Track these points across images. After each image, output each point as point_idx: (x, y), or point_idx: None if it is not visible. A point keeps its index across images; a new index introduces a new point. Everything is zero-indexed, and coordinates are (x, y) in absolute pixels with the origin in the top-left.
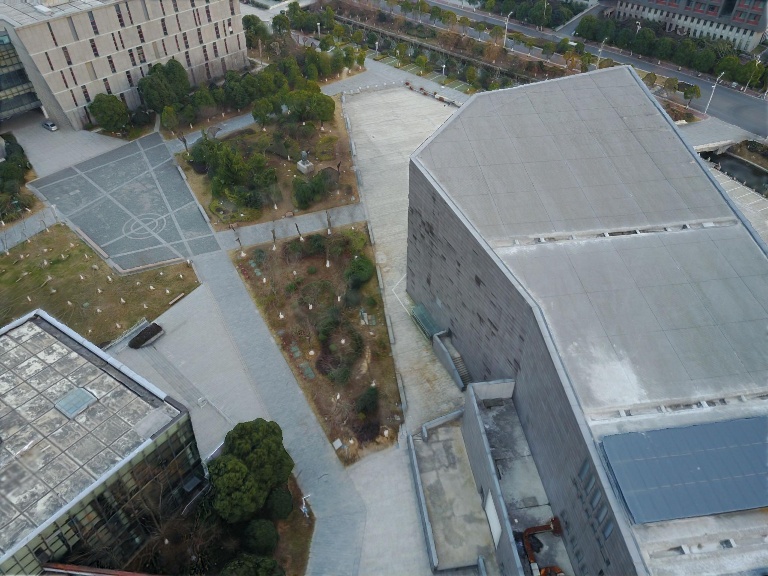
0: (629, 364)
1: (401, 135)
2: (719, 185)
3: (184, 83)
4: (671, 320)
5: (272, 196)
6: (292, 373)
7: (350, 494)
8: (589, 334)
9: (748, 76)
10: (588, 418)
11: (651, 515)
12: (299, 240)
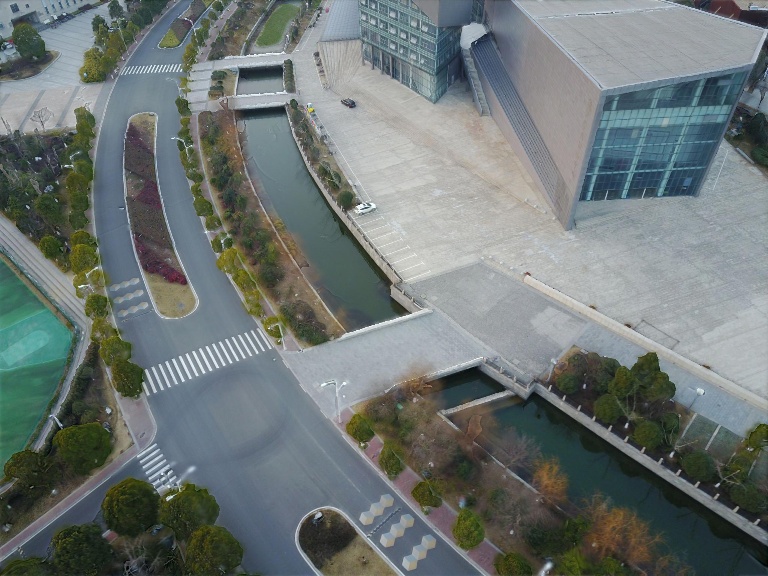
0: None
1: None
2: (539, 27)
3: None
4: None
5: None
6: (760, 111)
7: None
8: None
9: (205, 491)
10: None
11: None
12: None
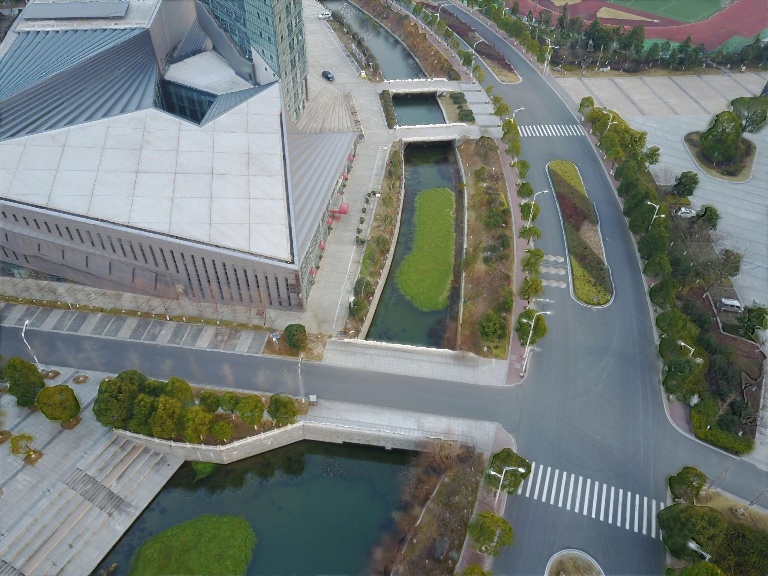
0: None
1: None
2: None
3: None
4: None
5: None
6: None
7: None
8: None
9: None
10: (35, 2)
11: None
12: None
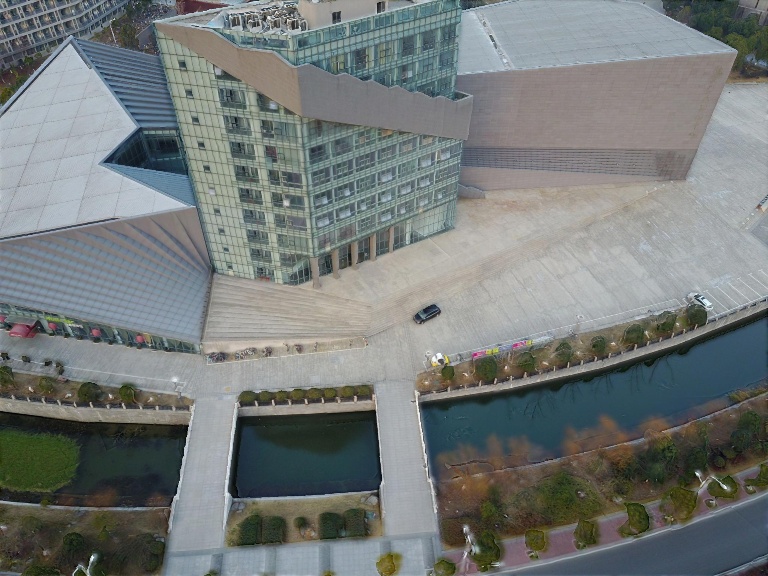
0: None
1: (741, 103)
2: (550, 66)
3: (728, 7)
4: None
5: None
6: None
7: None
8: None
9: None
10: None
11: None
12: None
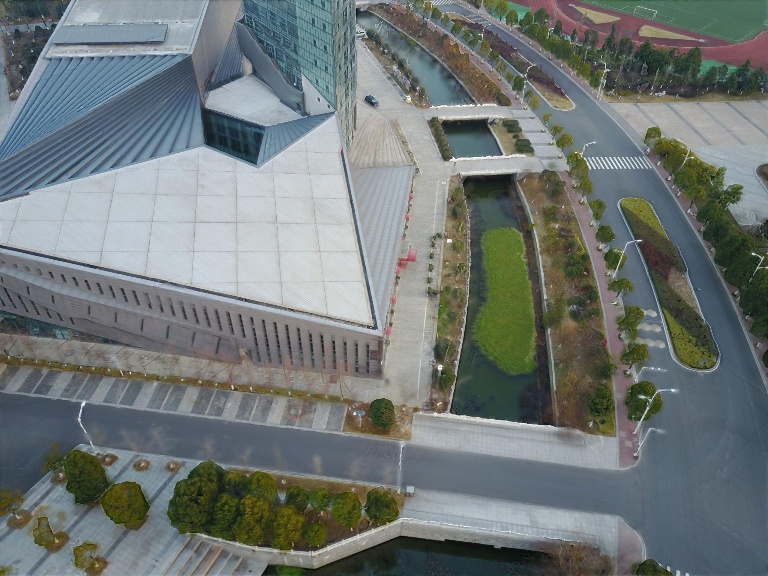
0: (100, 13)
1: None
2: None
3: None
4: (136, 3)
5: (39, 9)
6: None
7: (7, 108)
8: (92, 5)
9: None
10: (64, 24)
11: (59, 41)
12: (46, 29)
